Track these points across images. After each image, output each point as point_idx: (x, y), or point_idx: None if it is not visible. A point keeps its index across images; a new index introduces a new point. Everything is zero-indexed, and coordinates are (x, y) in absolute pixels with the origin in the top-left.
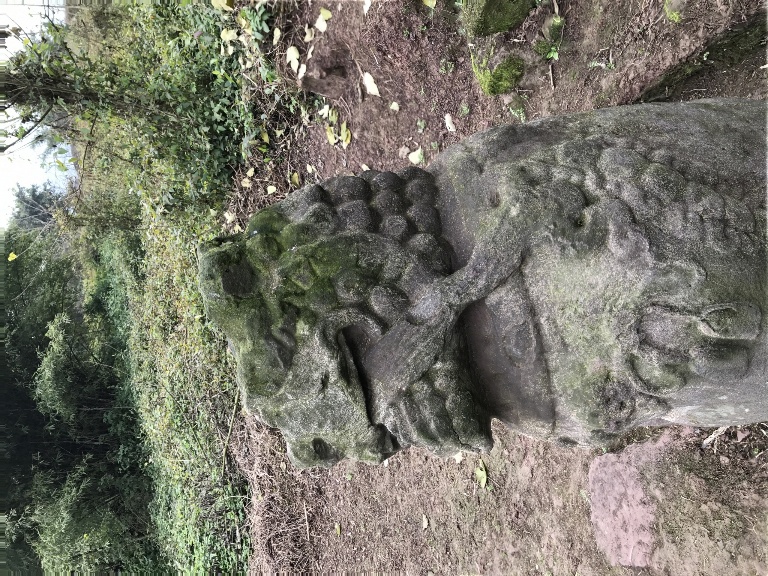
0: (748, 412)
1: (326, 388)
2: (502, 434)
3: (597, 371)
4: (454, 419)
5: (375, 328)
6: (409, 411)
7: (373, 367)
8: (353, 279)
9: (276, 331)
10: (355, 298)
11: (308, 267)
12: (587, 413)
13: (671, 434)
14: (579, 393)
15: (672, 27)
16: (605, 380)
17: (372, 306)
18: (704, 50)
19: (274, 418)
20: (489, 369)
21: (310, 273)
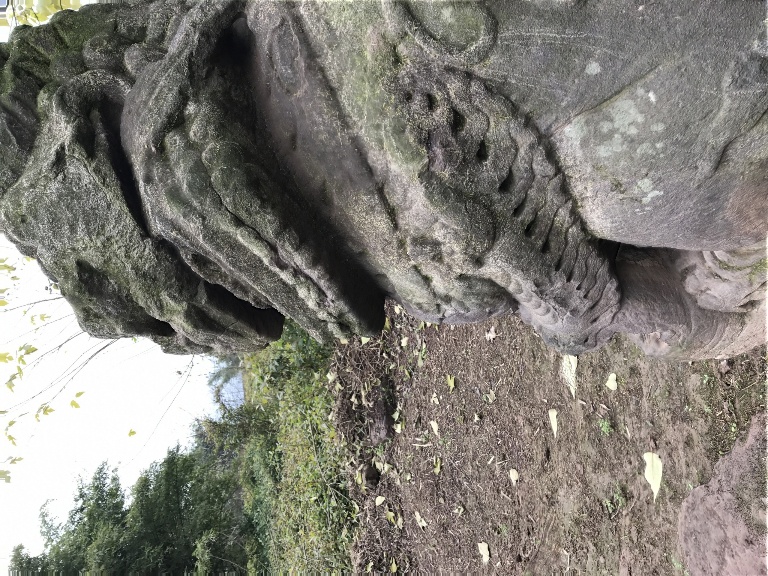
0: (657, 101)
1: (64, 164)
2: (594, 536)
3: (377, 50)
4: (212, 174)
5: (127, 89)
6: (160, 176)
7: (124, 135)
8: (100, 36)
9: (6, 98)
10: (104, 58)
11: (52, 31)
12: (389, 131)
13: (759, 420)
14: (370, 101)
15: None
16: (395, 65)
17: (127, 69)
18: None
19: (20, 226)
20: (283, 134)
21: (54, 38)
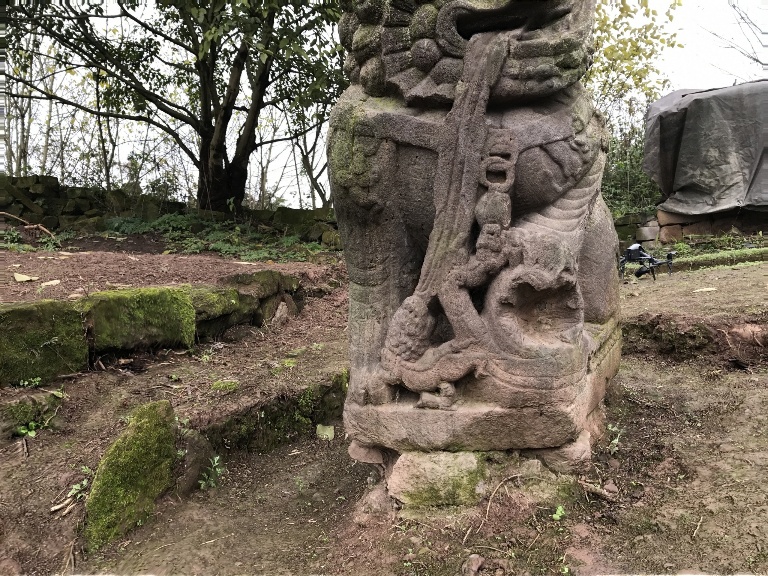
0: None
1: None
2: None
3: None
4: None
5: None
6: None
7: None
8: None
9: None
10: None
11: None
12: None
13: (577, 544)
14: None
15: (234, 386)
16: None
17: None
18: (265, 405)
19: None
20: None
21: None
